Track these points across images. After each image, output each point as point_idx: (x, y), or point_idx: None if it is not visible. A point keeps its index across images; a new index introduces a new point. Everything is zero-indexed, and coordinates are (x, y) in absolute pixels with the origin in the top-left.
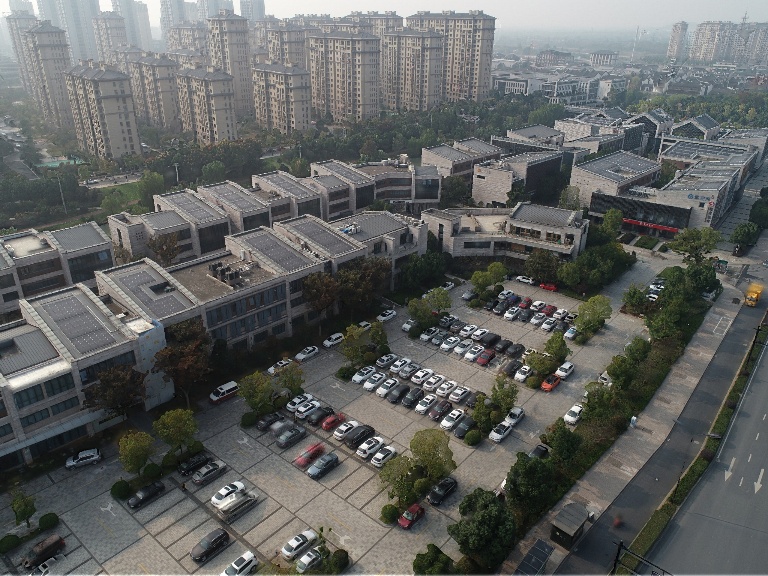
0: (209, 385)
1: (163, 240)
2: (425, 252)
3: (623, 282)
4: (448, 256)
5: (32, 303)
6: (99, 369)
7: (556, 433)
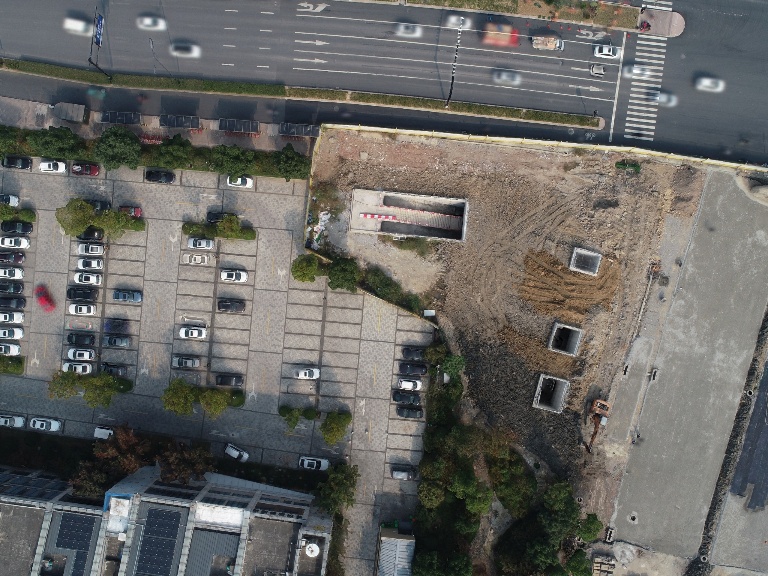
0: None
1: None
2: None
3: None
4: None
5: None
6: None
7: None
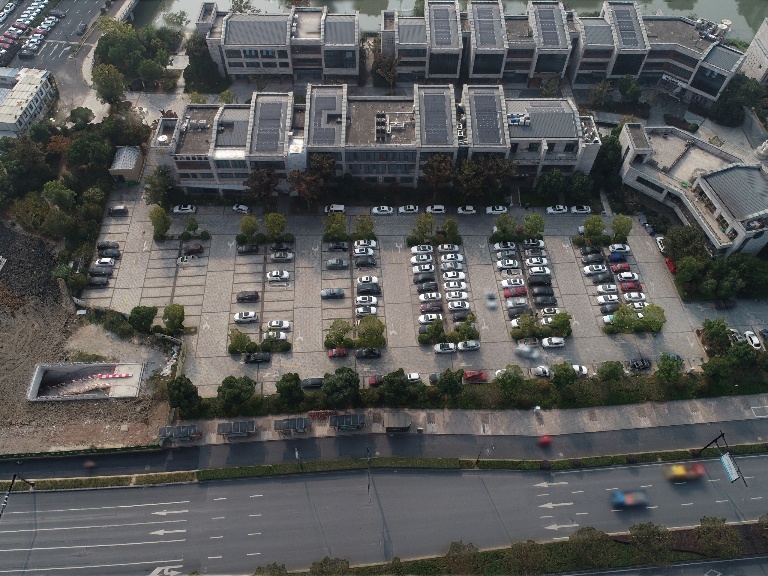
0: (335, 198)
1: (387, 61)
2: (588, 168)
3: (762, 306)
4: (614, 180)
5: (259, 97)
6: (263, 164)
7: (445, 375)
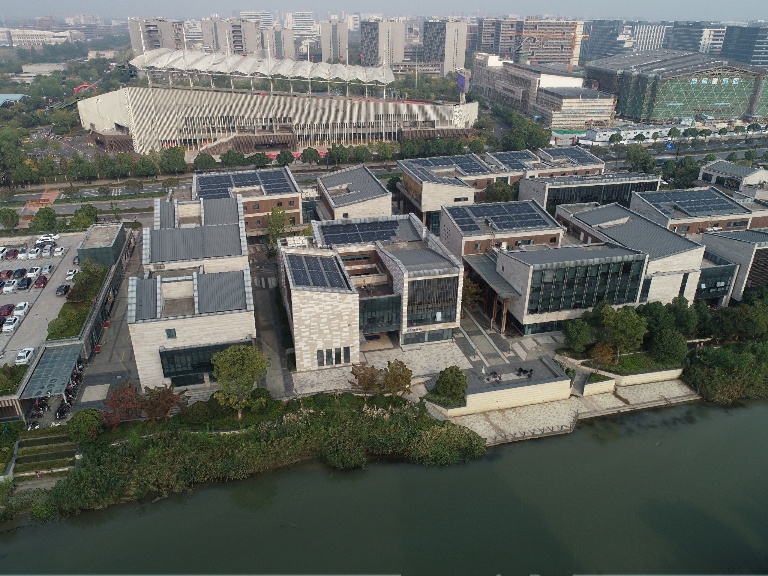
0: None
1: None
2: None
3: None
4: None
5: None
6: None
7: None
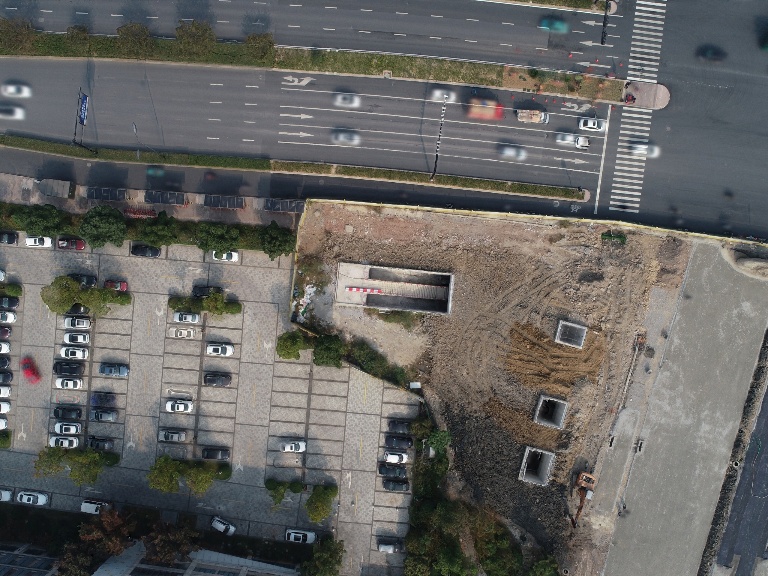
0: None
1: None
2: None
3: None
4: None
5: None
6: None
7: None
